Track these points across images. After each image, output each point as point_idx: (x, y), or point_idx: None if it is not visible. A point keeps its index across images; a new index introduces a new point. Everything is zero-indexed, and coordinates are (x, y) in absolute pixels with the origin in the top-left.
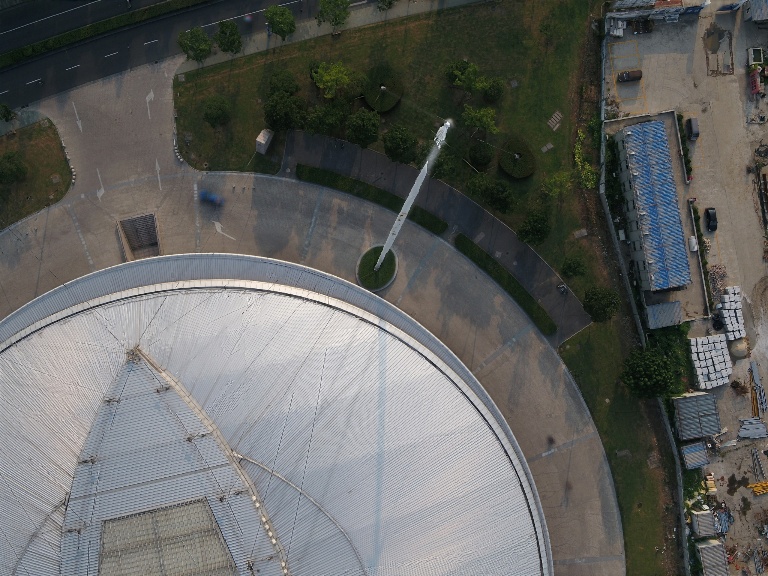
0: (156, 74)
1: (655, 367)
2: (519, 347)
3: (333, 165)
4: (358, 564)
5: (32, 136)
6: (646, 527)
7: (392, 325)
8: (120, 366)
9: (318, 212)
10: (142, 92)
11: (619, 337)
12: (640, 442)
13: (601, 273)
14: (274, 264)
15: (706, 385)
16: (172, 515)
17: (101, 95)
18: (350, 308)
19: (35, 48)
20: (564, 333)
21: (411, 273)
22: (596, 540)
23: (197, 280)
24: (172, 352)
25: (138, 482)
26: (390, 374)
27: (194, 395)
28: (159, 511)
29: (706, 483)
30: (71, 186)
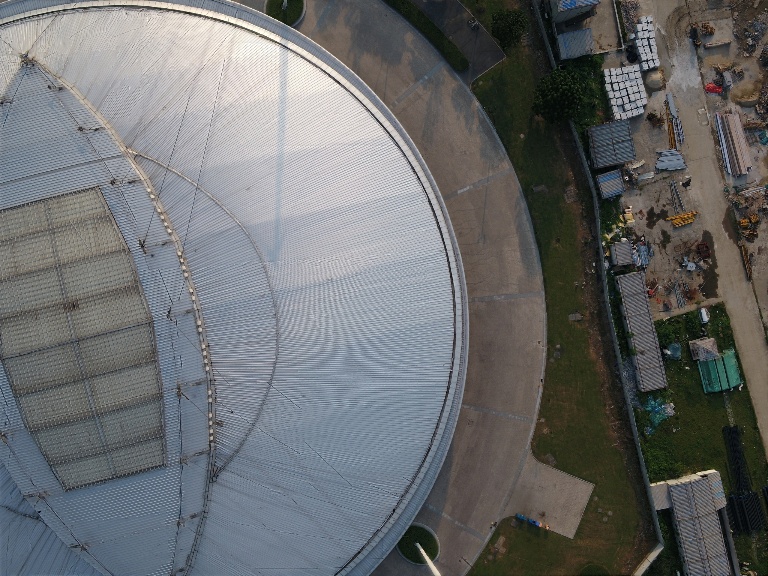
0: None
1: (561, 77)
2: (431, 84)
3: None
4: (257, 257)
5: None
6: (565, 262)
7: (294, 44)
8: None
9: None
10: None
11: (532, 71)
12: (556, 177)
13: (512, 7)
14: None
15: (621, 115)
16: (64, 203)
17: None
18: (251, 26)
19: None
20: (476, 69)
21: (320, 12)
22: (515, 277)
23: (95, 1)
24: (68, 62)
25: (30, 174)
26: (291, 85)
27: (89, 98)
28: (51, 200)
29: (624, 216)
30: None
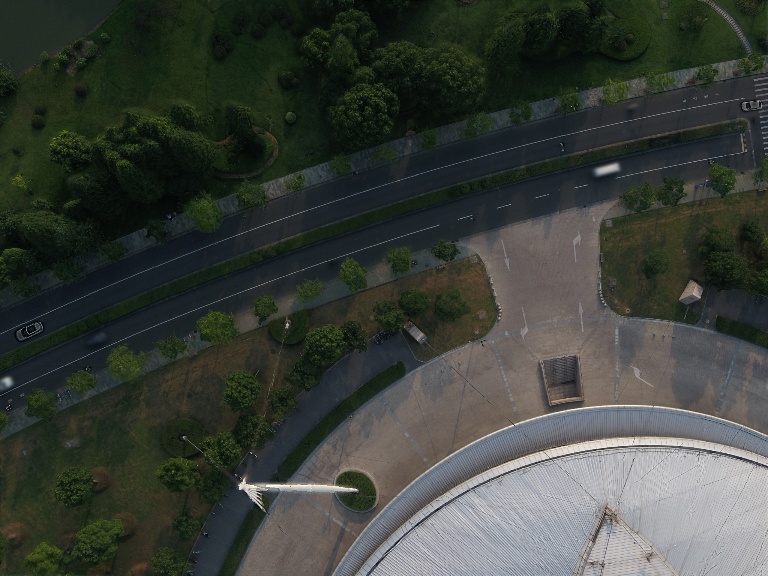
0: (584, 218)
1: None
2: None
3: (751, 319)
4: None
5: (461, 271)
6: None
7: None
8: (591, 524)
9: (734, 364)
10: (570, 235)
11: None
12: None
13: None
14: (711, 421)
15: None
16: None
17: (530, 235)
18: None
19: (473, 186)
20: None
21: None
22: None
23: (651, 437)
24: (642, 513)
25: None
26: None
27: (670, 561)
28: None
29: None
30: (496, 323)
